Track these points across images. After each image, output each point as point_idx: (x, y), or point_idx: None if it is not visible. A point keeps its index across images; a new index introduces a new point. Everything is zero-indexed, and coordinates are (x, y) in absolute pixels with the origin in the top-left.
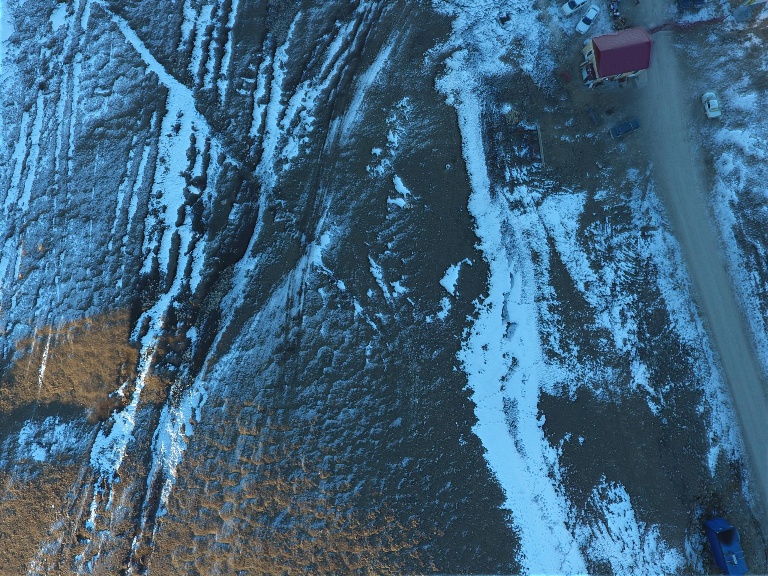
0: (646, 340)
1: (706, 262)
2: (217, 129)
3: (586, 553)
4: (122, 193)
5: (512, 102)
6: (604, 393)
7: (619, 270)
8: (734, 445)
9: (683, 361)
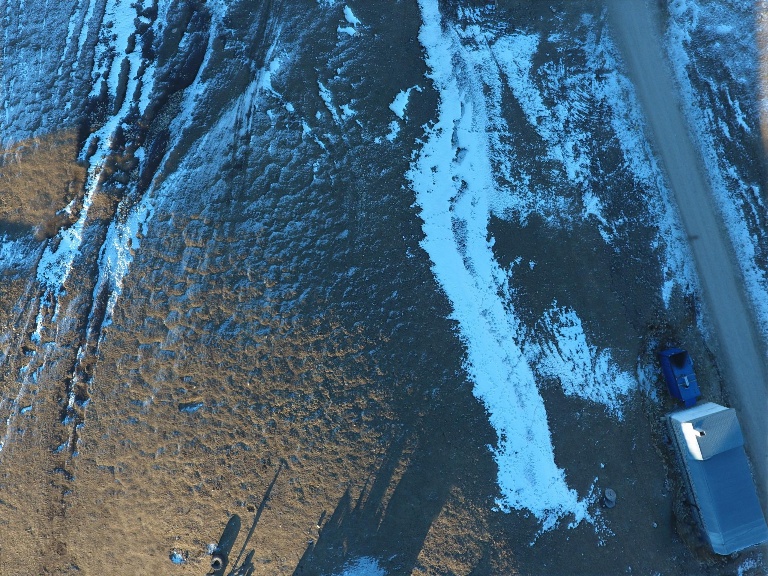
0: (599, 175)
1: (660, 102)
2: None
3: (535, 368)
4: (73, 23)
5: None
6: (555, 220)
7: (573, 109)
8: (688, 280)
9: (637, 198)
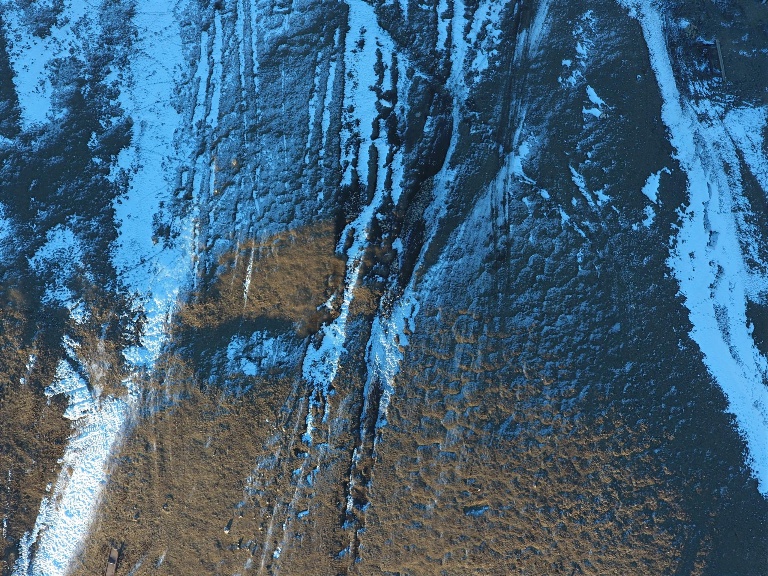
0: None
1: None
2: (403, 44)
3: None
4: (313, 108)
5: (689, 17)
6: None
7: None
8: None
9: None
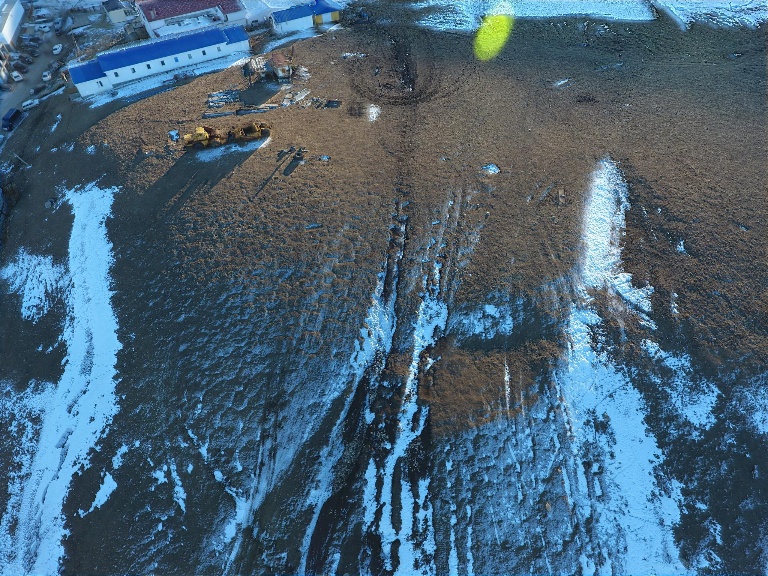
0: None
1: None
2: None
3: (66, 270)
4: None
5: None
6: (4, 388)
7: None
8: None
9: None
